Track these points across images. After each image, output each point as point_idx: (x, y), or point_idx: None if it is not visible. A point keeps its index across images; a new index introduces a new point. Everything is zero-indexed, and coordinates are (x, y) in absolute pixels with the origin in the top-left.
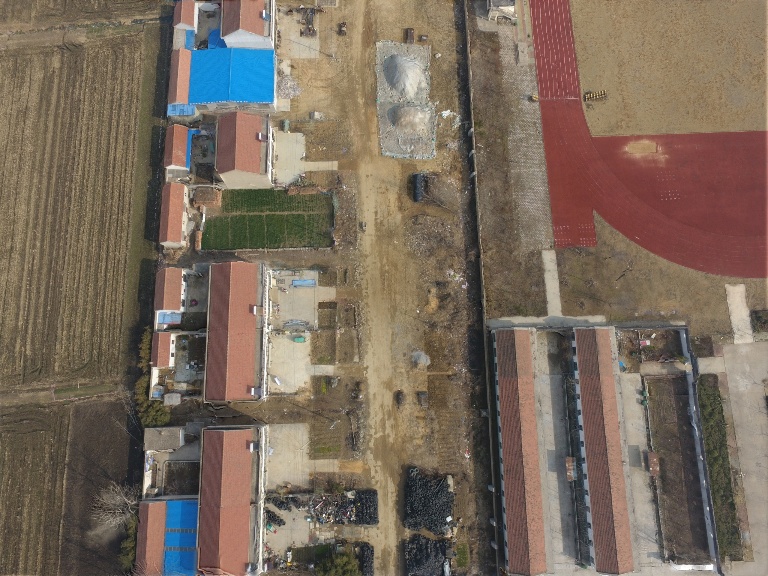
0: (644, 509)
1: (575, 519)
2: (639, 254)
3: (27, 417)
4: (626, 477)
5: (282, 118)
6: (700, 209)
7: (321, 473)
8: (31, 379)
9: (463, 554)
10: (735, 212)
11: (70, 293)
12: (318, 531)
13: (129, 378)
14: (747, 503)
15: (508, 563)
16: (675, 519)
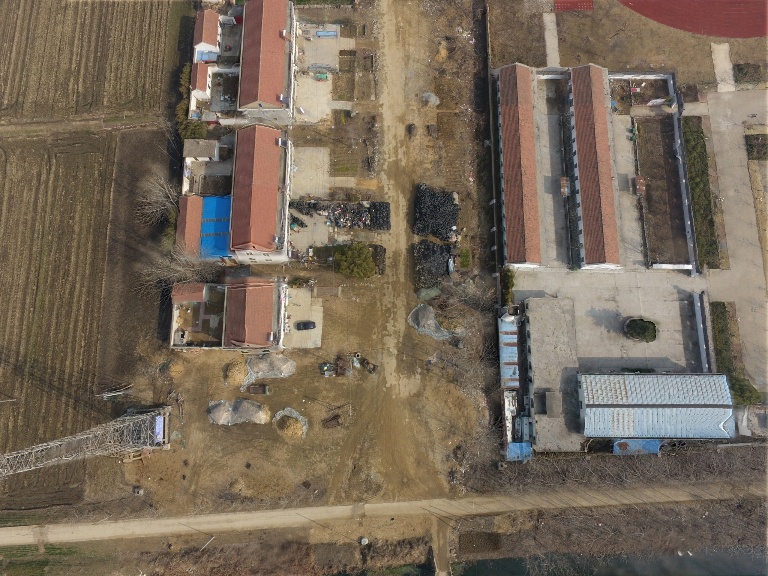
0: (631, 225)
1: (568, 230)
2: (632, 17)
3: (79, 141)
4: (615, 190)
5: None
6: None
7: (340, 188)
8: (83, 111)
9: (466, 257)
10: None
11: (118, 42)
12: (336, 234)
13: (169, 112)
14: (725, 222)
15: (506, 257)
16: (659, 234)
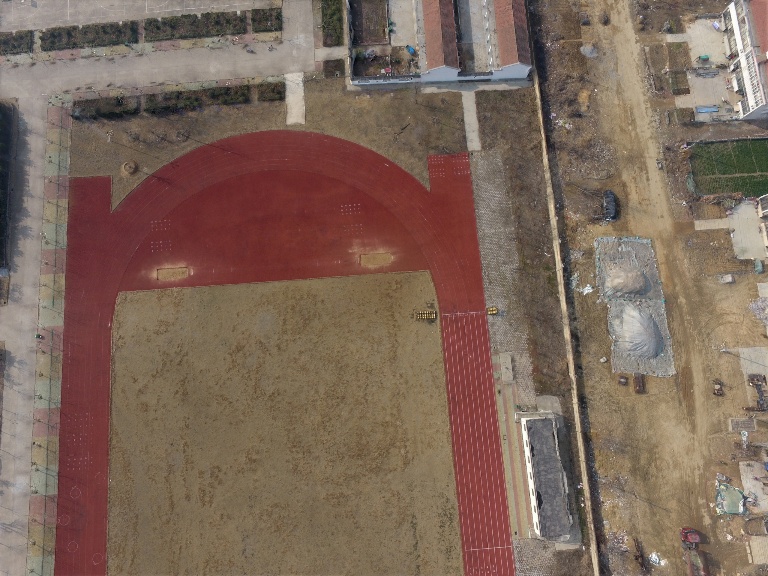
0: None
1: None
2: (386, 149)
3: None
4: None
5: (763, 275)
6: (321, 196)
7: None
8: None
9: None
10: (286, 194)
11: None
12: None
13: None
14: None
15: None
16: None
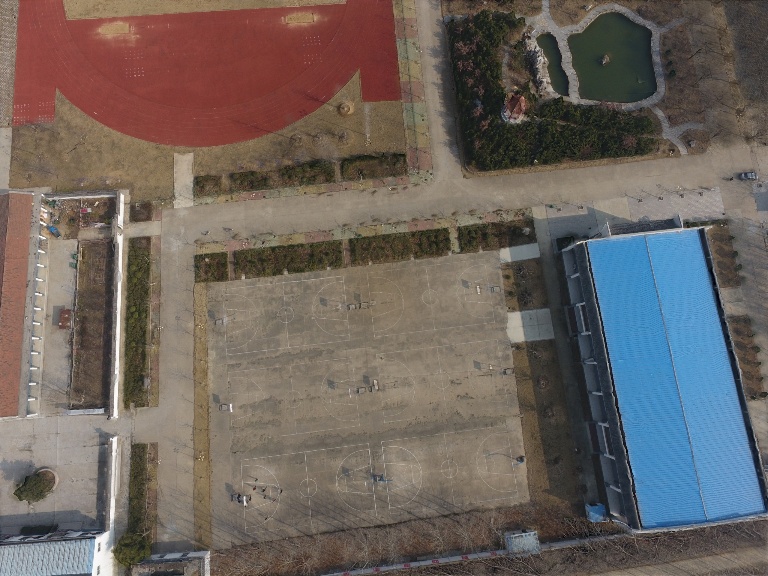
0: (60, 364)
1: None
2: (94, 128)
3: None
4: (26, 331)
5: None
6: (162, 84)
7: None
8: None
9: None
10: (196, 86)
11: None
12: None
13: None
14: (160, 354)
15: None
16: (88, 372)
